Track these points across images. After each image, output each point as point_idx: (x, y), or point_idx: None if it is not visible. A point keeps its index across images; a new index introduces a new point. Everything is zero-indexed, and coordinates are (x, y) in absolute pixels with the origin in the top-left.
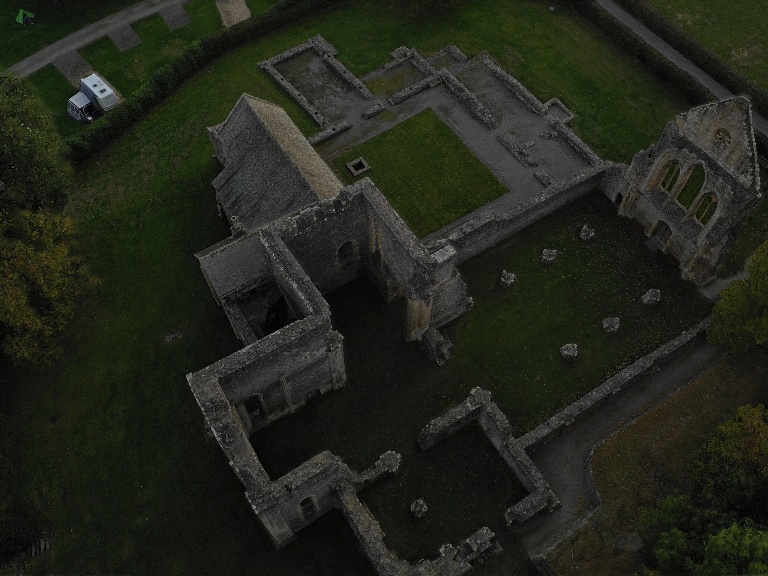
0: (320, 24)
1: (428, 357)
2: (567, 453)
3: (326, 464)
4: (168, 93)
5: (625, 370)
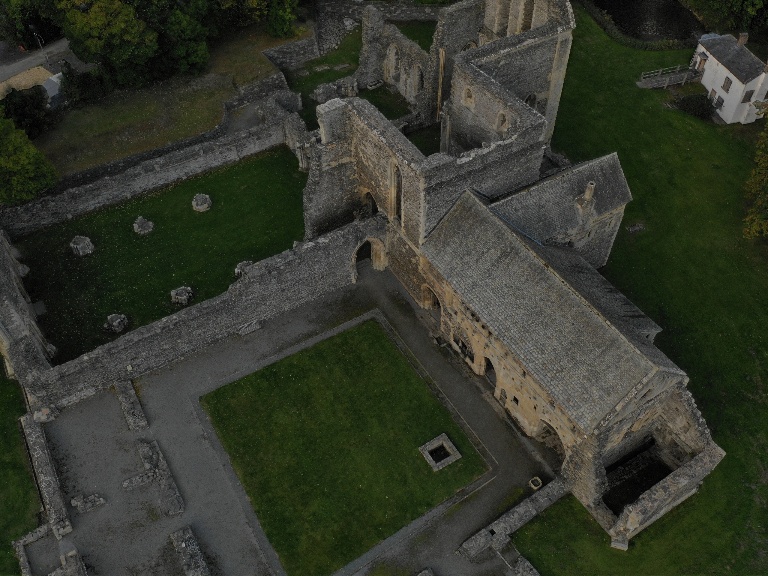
0: None
1: None
2: None
3: (445, 8)
4: None
5: (158, 164)
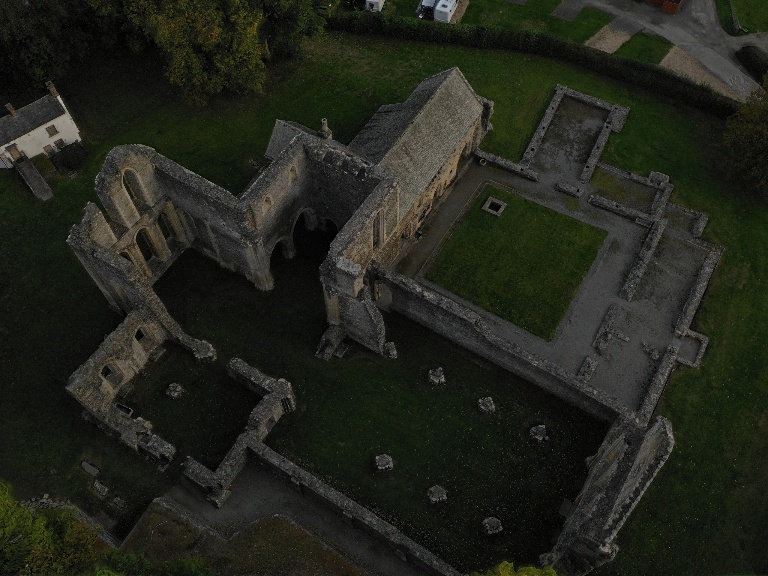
0: (644, 104)
1: (319, 343)
2: (274, 497)
3: (120, 267)
4: (479, 46)
5: (374, 515)
